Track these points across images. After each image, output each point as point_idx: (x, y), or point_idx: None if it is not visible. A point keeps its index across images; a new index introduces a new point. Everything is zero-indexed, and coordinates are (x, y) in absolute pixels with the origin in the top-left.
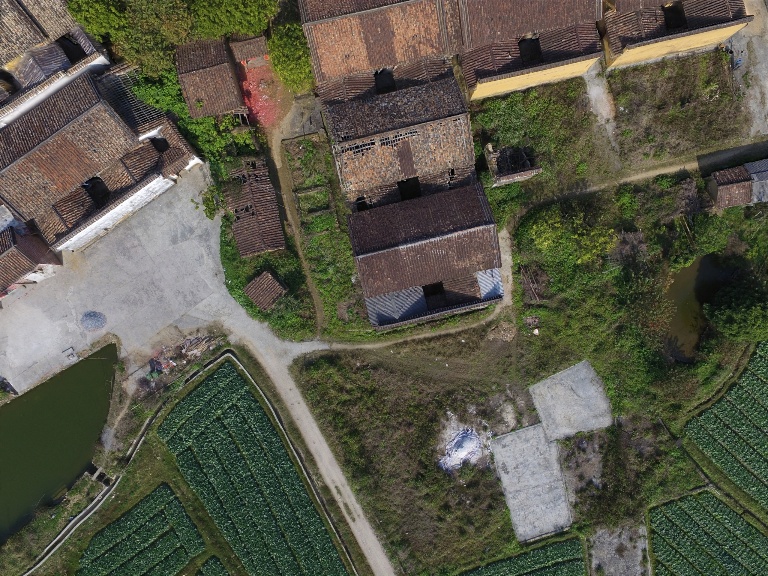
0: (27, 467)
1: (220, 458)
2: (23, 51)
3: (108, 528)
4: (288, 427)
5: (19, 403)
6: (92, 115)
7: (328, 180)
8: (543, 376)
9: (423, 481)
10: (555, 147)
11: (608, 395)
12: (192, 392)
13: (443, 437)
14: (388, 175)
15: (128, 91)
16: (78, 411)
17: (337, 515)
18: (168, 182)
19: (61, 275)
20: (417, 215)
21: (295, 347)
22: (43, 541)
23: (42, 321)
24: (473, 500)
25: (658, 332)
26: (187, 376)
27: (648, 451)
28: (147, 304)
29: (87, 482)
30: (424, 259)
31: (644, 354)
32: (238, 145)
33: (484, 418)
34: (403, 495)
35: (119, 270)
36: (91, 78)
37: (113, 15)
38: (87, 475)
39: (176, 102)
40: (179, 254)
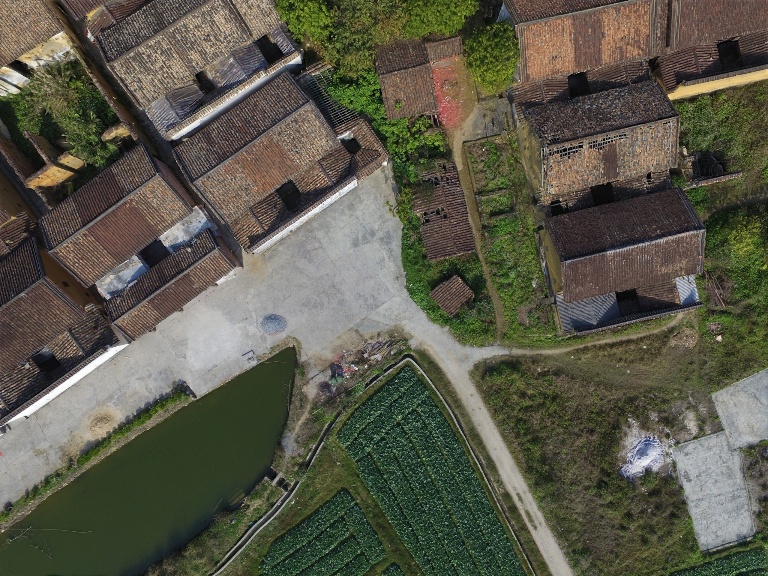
0: (204, 471)
1: (400, 464)
2: (229, 50)
3: (288, 534)
4: (469, 433)
5: (195, 407)
6: (299, 116)
7: (512, 183)
8: (726, 383)
9: (608, 489)
10: (743, 151)
11: None
12: (373, 397)
13: (624, 444)
14: (590, 178)
15: (323, 91)
16: (255, 415)
17: (519, 523)
18: (355, 184)
19: (241, 277)
20: (620, 219)
21: (476, 352)
22: (224, 547)
23: (222, 324)
24: (655, 508)
25: None
26: (367, 380)
27: None
28: (328, 307)
29: (267, 487)
30: (628, 264)
31: None
32: None
33: (667, 425)
34: (584, 503)
35: (299, 273)
36: (293, 78)
37: (323, 14)
38: (267, 480)
39: (369, 103)
40: (360, 257)
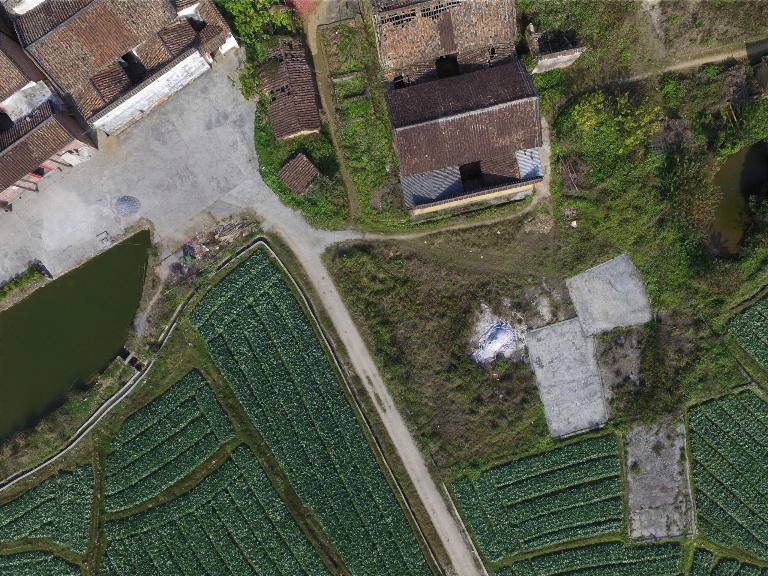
0: (60, 351)
1: (251, 345)
2: None
3: (139, 412)
4: (320, 315)
5: (53, 288)
6: None
7: (364, 66)
8: (580, 269)
9: (456, 372)
10: (598, 33)
11: (648, 290)
12: (224, 278)
13: (477, 330)
14: (427, 50)
15: None
16: (111, 297)
17: (368, 405)
18: (204, 63)
19: (96, 159)
20: (457, 91)
21: (328, 236)
22: (76, 423)
23: (77, 205)
24: (506, 394)
25: (702, 220)
26: (219, 263)
27: (688, 348)
28: (181, 189)
29: (119, 366)
30: (463, 135)
31: (686, 248)
32: (274, 26)
33: (519, 310)
34: (435, 387)
35: (153, 155)
36: None
37: None
38: (119, 359)
39: None
40: (213, 140)
